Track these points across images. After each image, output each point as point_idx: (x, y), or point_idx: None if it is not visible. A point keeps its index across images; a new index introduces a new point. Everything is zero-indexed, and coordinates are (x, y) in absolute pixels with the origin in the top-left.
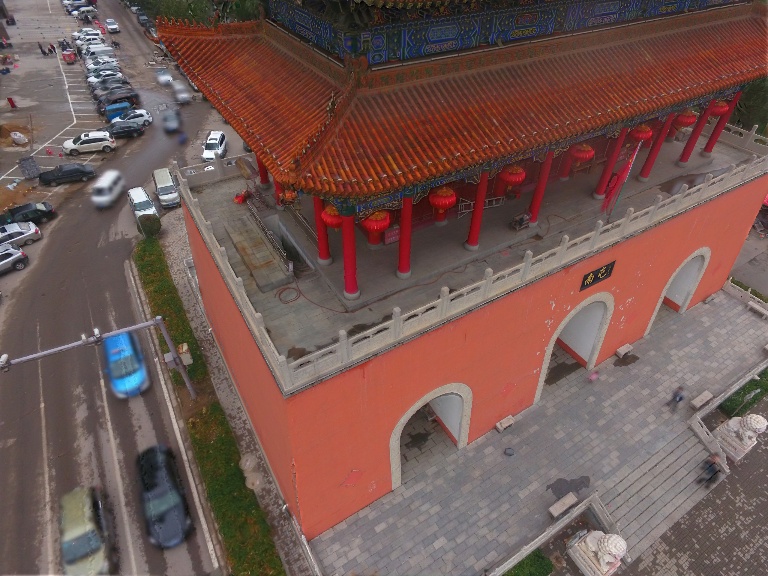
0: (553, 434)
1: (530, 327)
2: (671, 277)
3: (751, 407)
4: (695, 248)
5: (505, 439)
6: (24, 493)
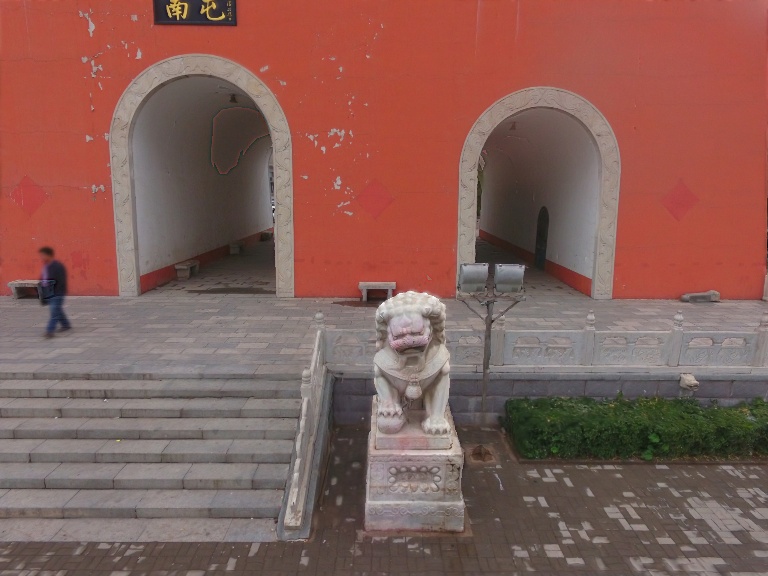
0: (61, 314)
1: (47, 54)
2: (472, 133)
3: (636, 460)
4: (530, 82)
5: (1, 302)
6: None
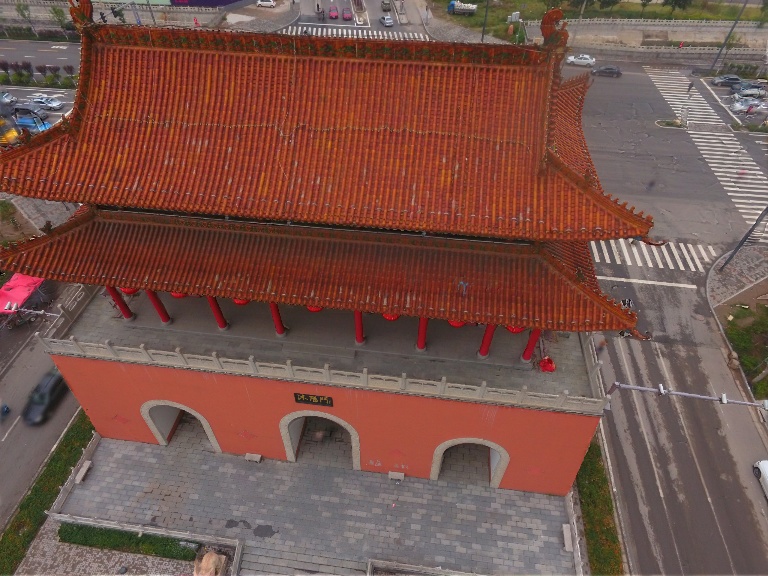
0: None
1: None
2: None
3: None
4: None
5: None
6: (698, 429)
